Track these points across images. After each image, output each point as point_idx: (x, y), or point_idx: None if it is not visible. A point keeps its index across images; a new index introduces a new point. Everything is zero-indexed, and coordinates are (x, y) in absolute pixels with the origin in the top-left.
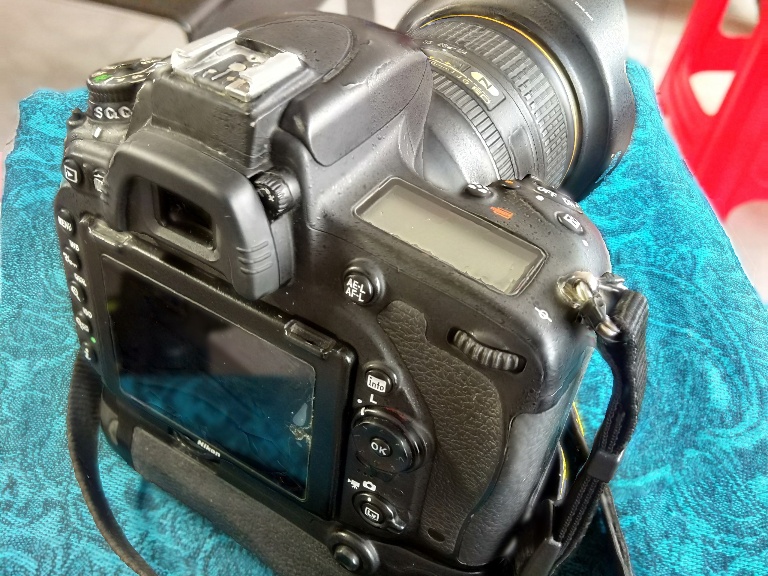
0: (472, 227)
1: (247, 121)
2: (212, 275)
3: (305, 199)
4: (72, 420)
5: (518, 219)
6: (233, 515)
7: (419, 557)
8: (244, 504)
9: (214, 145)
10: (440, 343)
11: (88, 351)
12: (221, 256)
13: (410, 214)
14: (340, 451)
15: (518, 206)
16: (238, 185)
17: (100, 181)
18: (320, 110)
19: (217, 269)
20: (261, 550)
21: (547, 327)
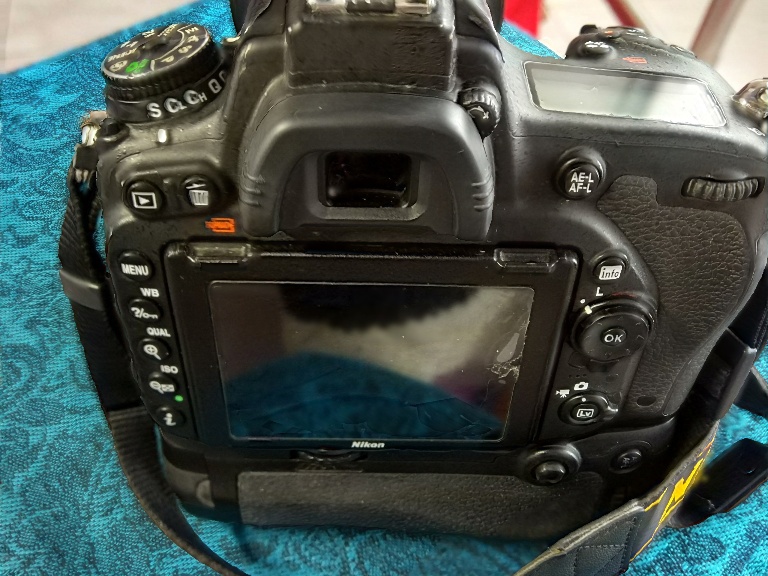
0: (629, 82)
1: (445, 34)
2: (378, 243)
3: (505, 106)
4: (151, 508)
5: (652, 61)
6: (393, 503)
7: (622, 433)
8: (404, 485)
9: (397, 80)
10: (673, 201)
11: (171, 415)
12: (428, 207)
13: (562, 93)
14: (552, 366)
15: (640, 50)
16: (451, 113)
17: (200, 191)
18: (478, 4)
19: (420, 226)
20: (434, 520)
21: (767, 141)
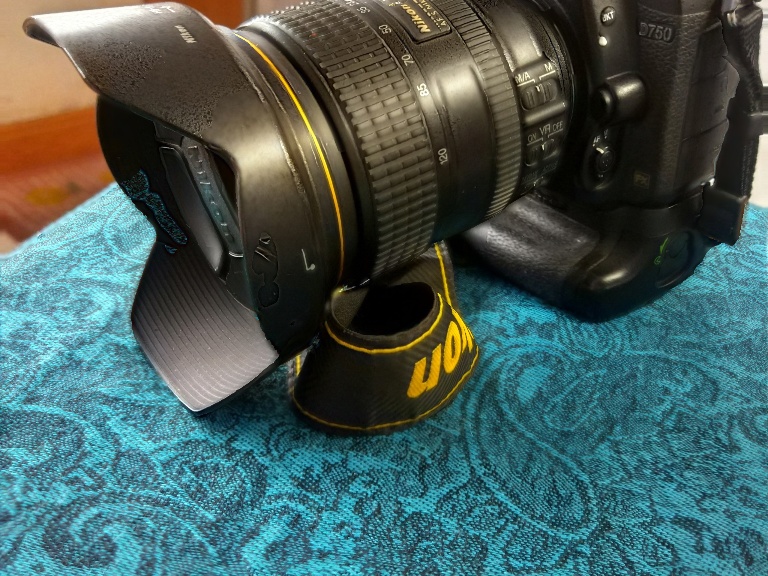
0: None
1: None
2: None
3: None
4: None
5: None
6: None
7: None
8: None
9: None
10: None
11: None
12: None
13: None
14: None
15: None
16: None
17: None
18: None
19: None
20: None
21: None
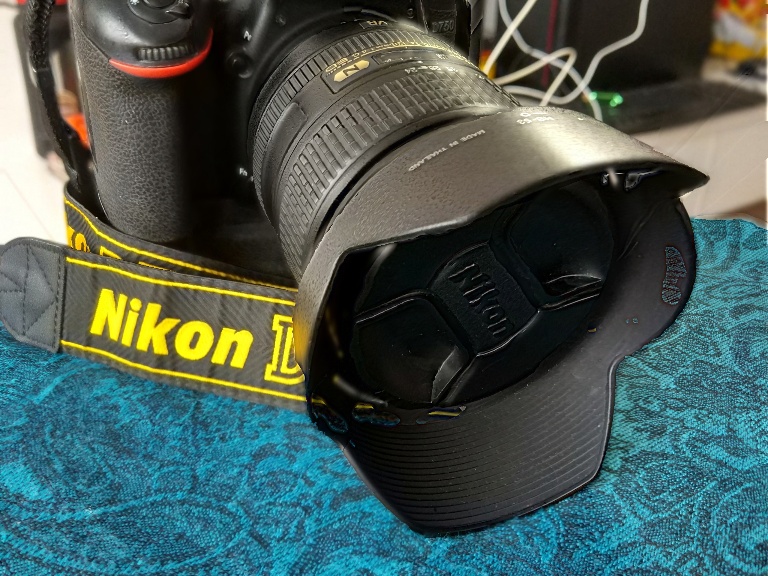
0: None
1: None
2: None
3: None
4: None
5: None
6: None
7: None
8: None
9: None
10: None
11: None
12: None
13: None
14: None
15: None
16: None
17: None
18: None
19: None
20: None
21: None
